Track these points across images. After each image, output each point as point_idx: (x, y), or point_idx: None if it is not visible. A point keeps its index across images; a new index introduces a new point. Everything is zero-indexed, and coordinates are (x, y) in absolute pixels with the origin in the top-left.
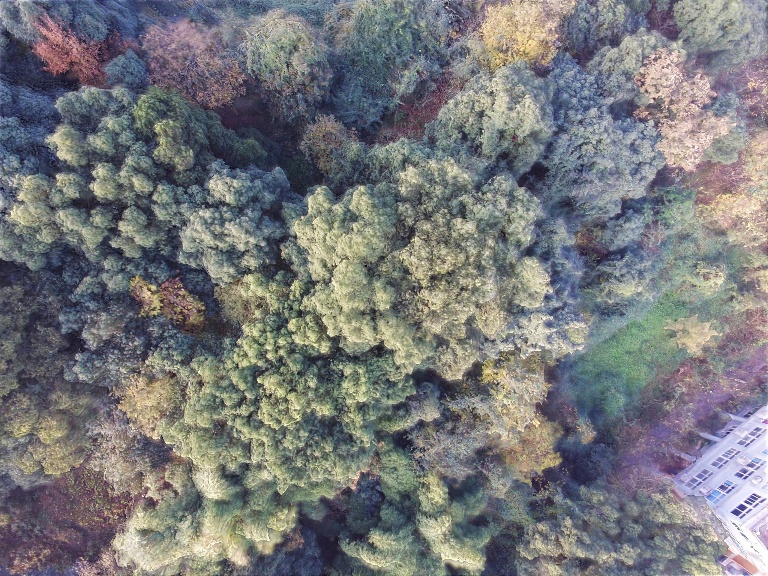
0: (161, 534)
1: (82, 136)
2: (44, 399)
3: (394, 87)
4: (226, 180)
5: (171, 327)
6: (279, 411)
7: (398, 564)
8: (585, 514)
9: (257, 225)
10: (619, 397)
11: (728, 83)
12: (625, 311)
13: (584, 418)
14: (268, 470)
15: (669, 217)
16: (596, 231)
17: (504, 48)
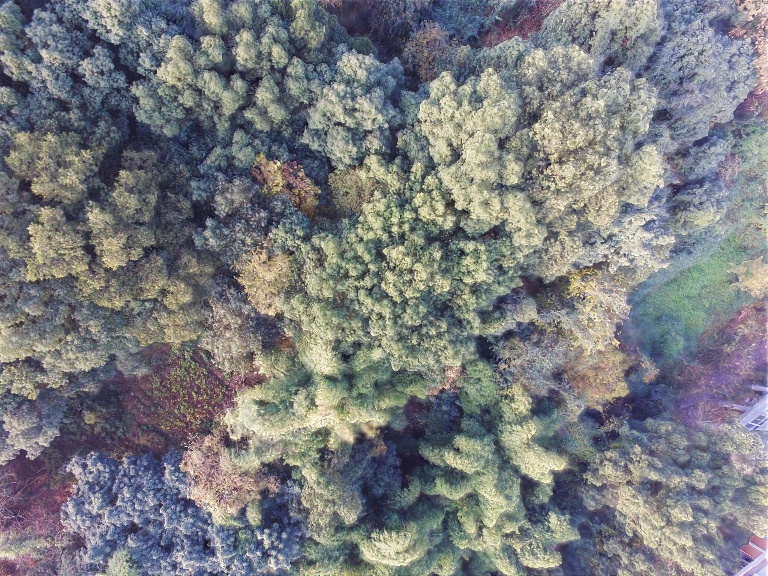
0: (276, 407)
1: (224, 3)
2: (173, 262)
3: (492, 3)
4: (358, 56)
5: (292, 205)
6: (403, 283)
7: (481, 472)
8: (653, 443)
9: (383, 105)
10: (679, 339)
11: None
12: (693, 249)
13: (647, 357)
14: (383, 348)
15: (747, 150)
16: (677, 159)
17: None
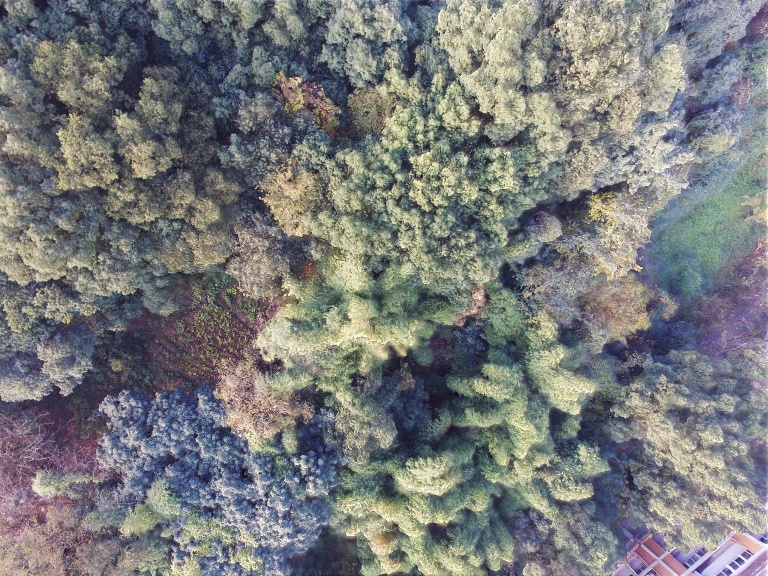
0: (309, 325)
1: None
2: (200, 181)
3: None
4: None
5: (314, 123)
6: (431, 190)
7: (511, 400)
8: (678, 373)
9: None
10: (697, 276)
11: None
12: (707, 181)
13: None
14: (412, 262)
15: (758, 73)
16: (690, 84)
17: None
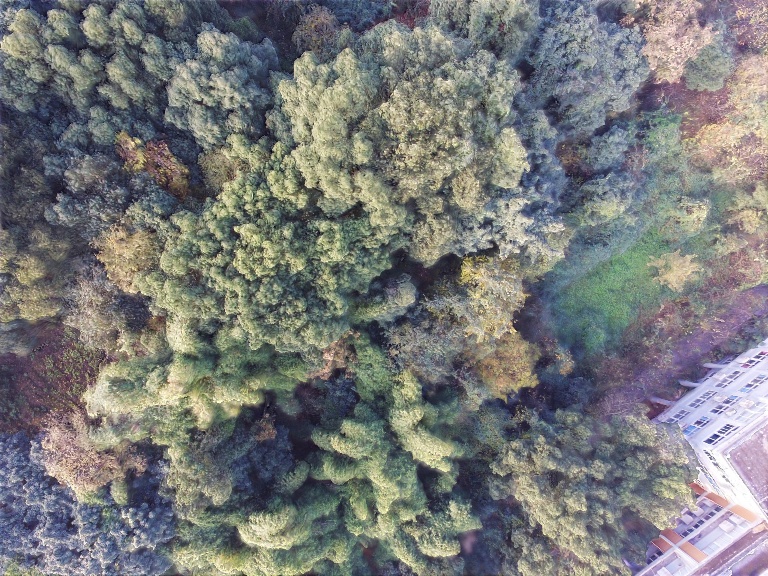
0: (132, 384)
1: None
2: (24, 237)
3: None
4: (214, 33)
5: (153, 183)
6: (254, 260)
7: (369, 458)
8: (559, 434)
9: (242, 84)
10: (600, 332)
11: (717, 12)
12: (608, 241)
13: (564, 349)
14: (241, 327)
15: (654, 141)
16: (581, 149)
17: None
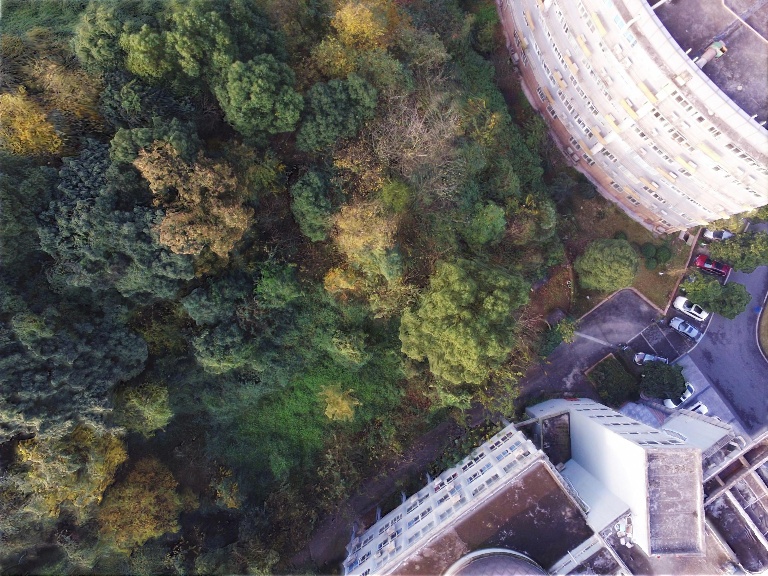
0: None
1: None
2: None
3: None
4: None
5: None
6: None
7: None
8: None
9: None
10: (280, 460)
11: (319, 160)
12: (260, 378)
13: (232, 482)
14: None
15: (263, 292)
16: (179, 306)
17: (8, 136)
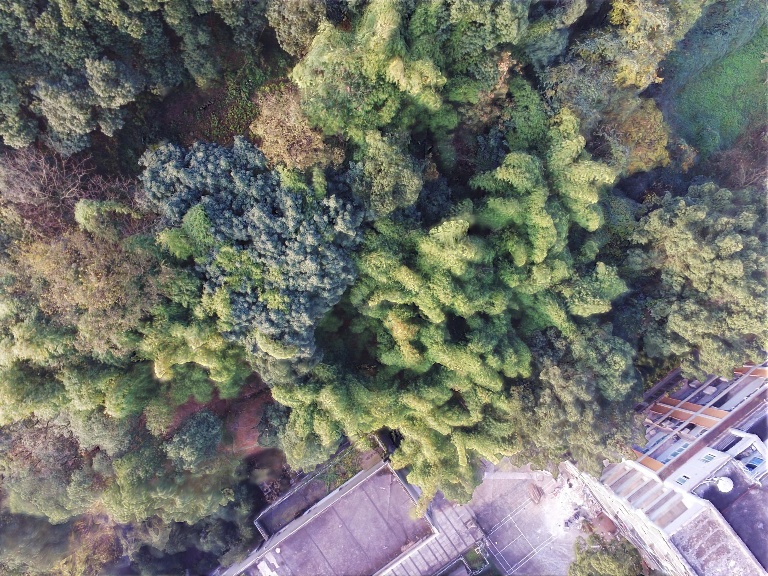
0: None
1: None
2: None
3: None
4: None
5: None
6: None
7: (532, 191)
8: (697, 202)
9: None
10: (716, 134)
11: None
12: (727, 29)
13: None
14: None
15: None
16: None
17: None
